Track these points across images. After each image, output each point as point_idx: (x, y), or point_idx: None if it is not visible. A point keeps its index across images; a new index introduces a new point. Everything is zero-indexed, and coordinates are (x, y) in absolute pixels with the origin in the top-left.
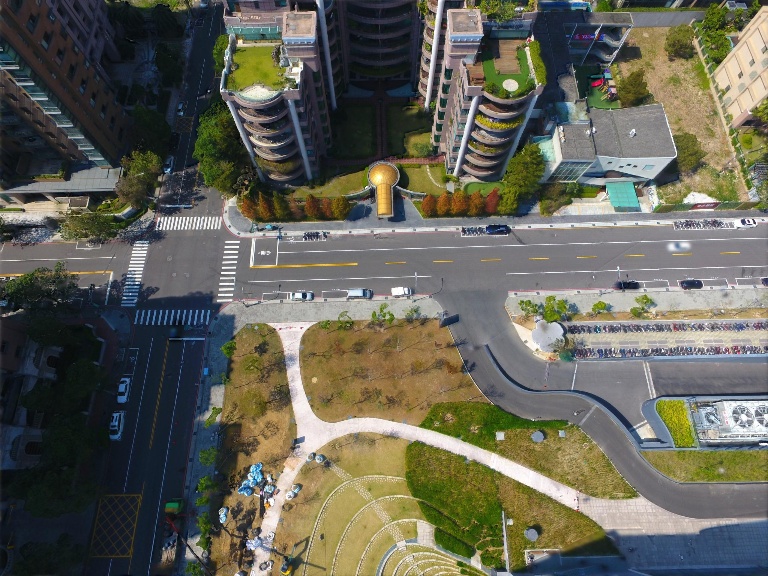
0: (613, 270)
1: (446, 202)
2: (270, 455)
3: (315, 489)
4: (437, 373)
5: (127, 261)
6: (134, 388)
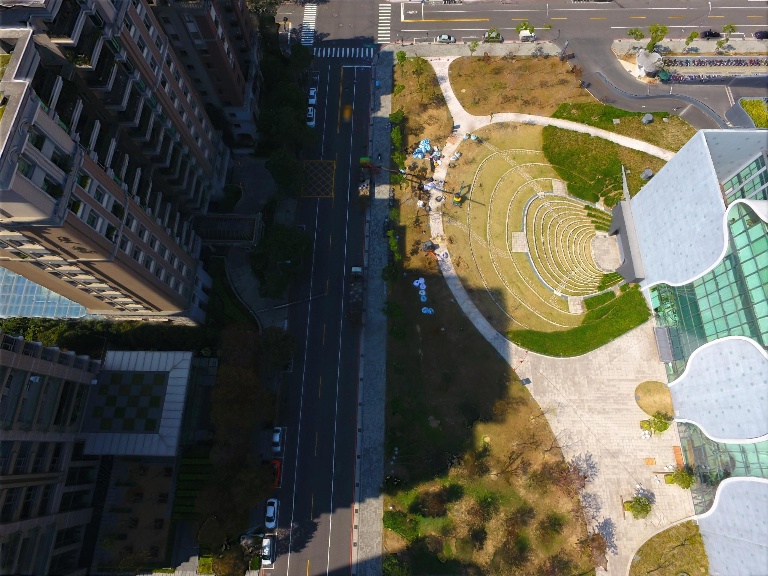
0: None
1: None
2: (434, 135)
3: (472, 156)
4: (561, 87)
5: (301, 16)
6: (319, 97)
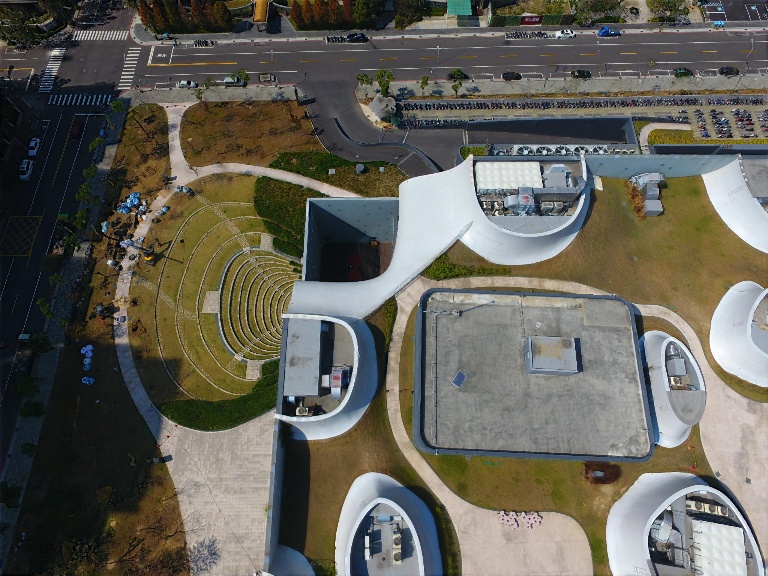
0: (449, 67)
1: (308, 7)
2: (147, 188)
3: (180, 210)
4: (290, 135)
5: (46, 61)
6: (43, 147)
